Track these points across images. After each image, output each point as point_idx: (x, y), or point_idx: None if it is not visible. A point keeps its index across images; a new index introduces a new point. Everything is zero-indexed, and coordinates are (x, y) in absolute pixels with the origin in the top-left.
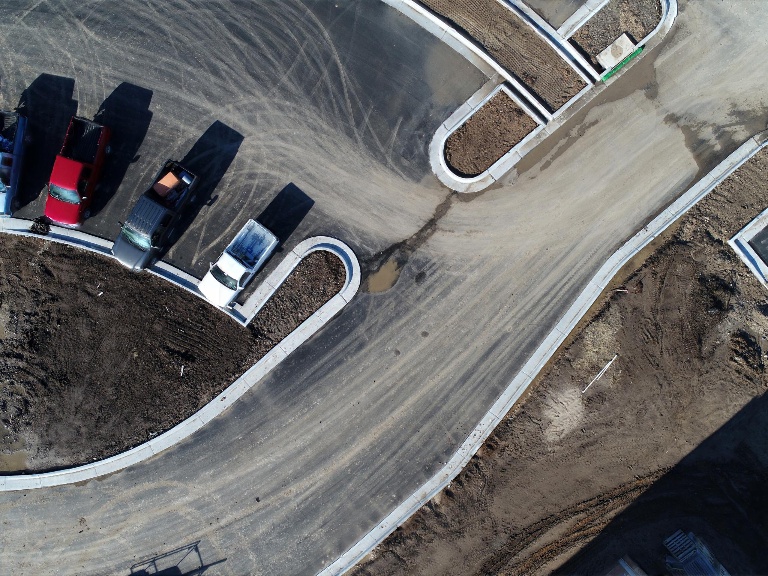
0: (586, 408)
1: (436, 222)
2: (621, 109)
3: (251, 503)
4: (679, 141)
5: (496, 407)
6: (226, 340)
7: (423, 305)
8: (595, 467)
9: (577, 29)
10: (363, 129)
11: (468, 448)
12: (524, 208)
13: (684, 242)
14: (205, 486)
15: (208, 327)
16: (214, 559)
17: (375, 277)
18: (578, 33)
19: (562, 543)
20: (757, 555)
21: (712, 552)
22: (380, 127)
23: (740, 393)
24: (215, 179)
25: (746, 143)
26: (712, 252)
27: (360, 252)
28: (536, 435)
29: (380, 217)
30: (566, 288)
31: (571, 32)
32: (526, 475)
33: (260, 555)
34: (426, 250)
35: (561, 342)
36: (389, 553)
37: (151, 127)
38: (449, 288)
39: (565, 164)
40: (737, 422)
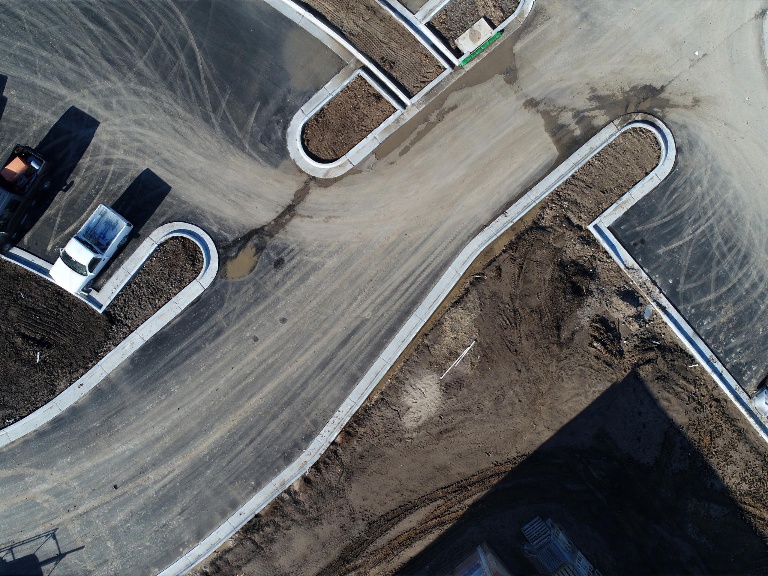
0: (444, 394)
1: (294, 208)
2: (480, 94)
3: (109, 490)
4: (539, 126)
5: (355, 393)
6: (82, 326)
7: (281, 291)
8: (453, 453)
9: (434, 13)
10: (220, 114)
11: (327, 435)
12: (383, 193)
13: (543, 227)
14: (62, 473)
15: (64, 313)
16: (72, 547)
17: (233, 263)
18: (436, 17)
19: (420, 530)
20: (616, 542)
21: (570, 539)
22: (237, 112)
23: (599, 379)
24: (71, 165)
25: (606, 128)
26: (572, 237)
27: (218, 238)
28: (394, 421)
29: (238, 203)
30: (425, 274)
31: (428, 16)
32: (384, 462)
33: (118, 542)
34: (284, 236)
35: (419, 328)
36: (247, 540)
37: (6, 113)
38: (307, 274)
39: (424, 149)
40: (596, 408)
